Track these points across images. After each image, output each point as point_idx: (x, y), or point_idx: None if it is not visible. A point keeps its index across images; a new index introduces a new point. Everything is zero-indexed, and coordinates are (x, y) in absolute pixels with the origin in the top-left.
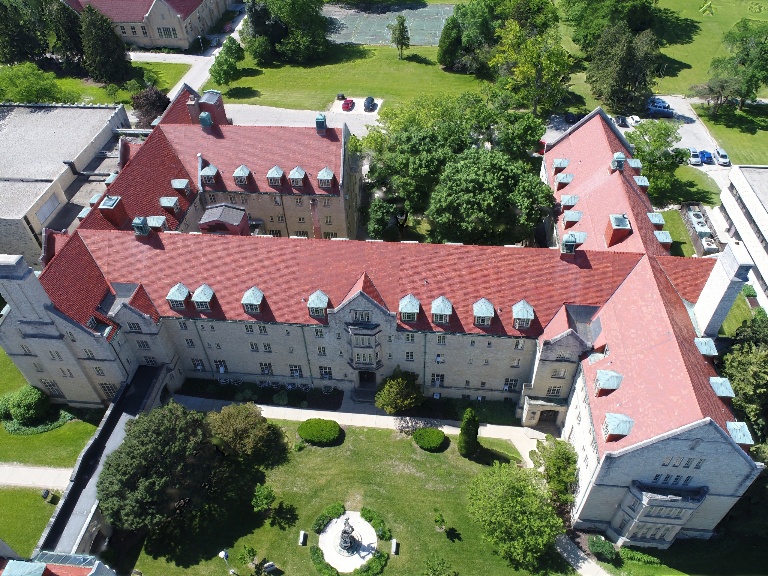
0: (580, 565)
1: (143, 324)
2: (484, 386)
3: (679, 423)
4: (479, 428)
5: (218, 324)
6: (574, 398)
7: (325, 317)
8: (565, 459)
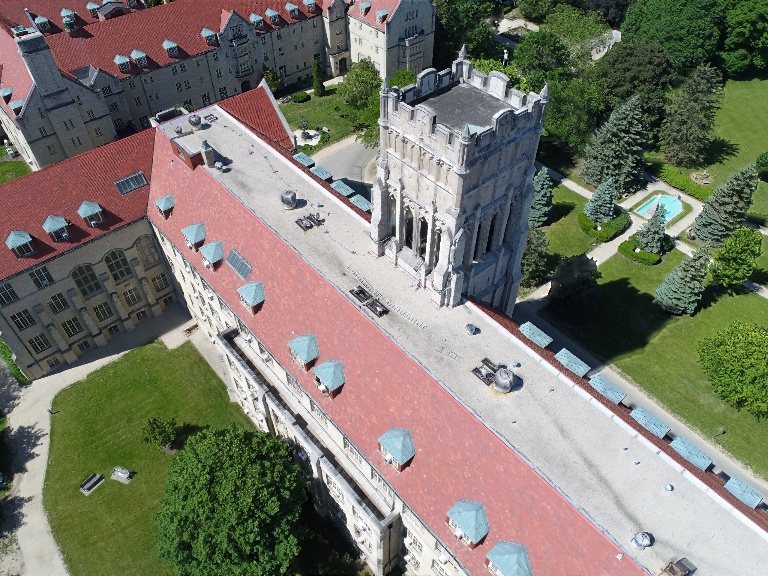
0: None
1: (113, 84)
2: (306, 66)
3: None
4: None
5: (155, 73)
6: (352, 39)
7: (216, 42)
8: (366, 63)
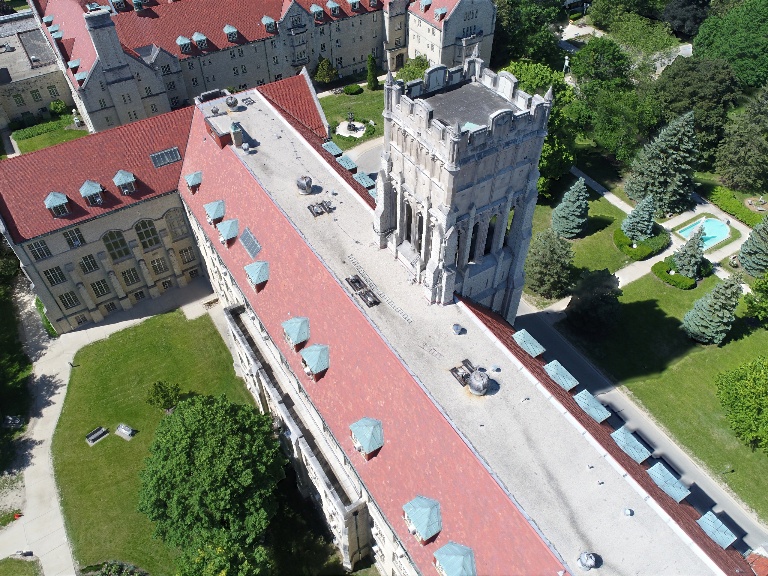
0: None
1: (173, 64)
2: (362, 59)
3: None
4: None
5: (214, 56)
6: (410, 35)
7: (275, 30)
8: (421, 60)
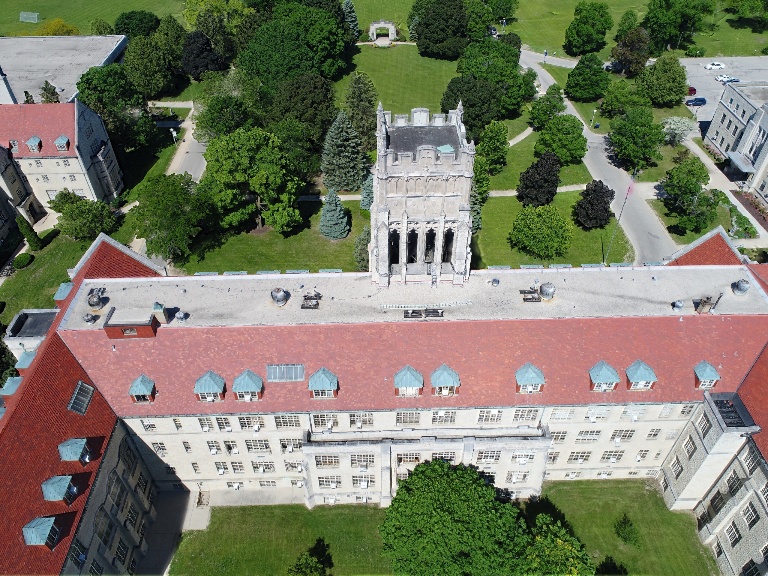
0: (123, 212)
1: None
2: None
3: (72, 114)
4: (25, 243)
5: None
6: (31, 180)
7: None
8: (65, 196)
